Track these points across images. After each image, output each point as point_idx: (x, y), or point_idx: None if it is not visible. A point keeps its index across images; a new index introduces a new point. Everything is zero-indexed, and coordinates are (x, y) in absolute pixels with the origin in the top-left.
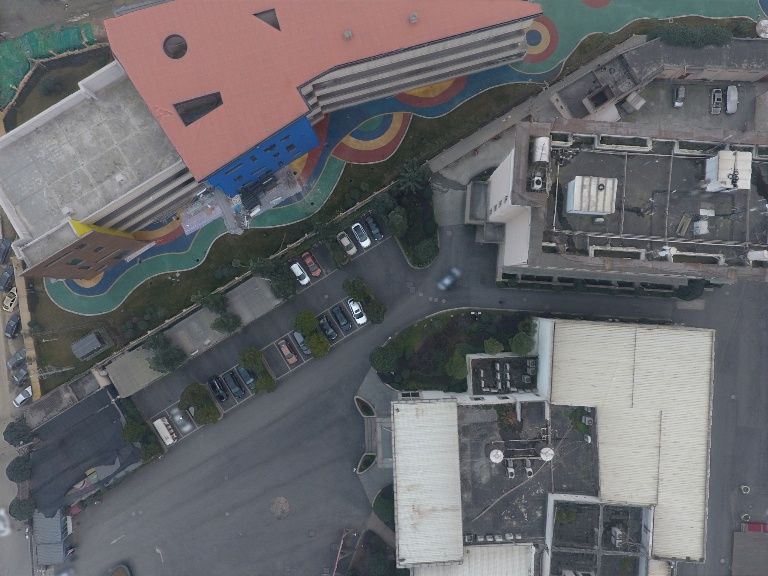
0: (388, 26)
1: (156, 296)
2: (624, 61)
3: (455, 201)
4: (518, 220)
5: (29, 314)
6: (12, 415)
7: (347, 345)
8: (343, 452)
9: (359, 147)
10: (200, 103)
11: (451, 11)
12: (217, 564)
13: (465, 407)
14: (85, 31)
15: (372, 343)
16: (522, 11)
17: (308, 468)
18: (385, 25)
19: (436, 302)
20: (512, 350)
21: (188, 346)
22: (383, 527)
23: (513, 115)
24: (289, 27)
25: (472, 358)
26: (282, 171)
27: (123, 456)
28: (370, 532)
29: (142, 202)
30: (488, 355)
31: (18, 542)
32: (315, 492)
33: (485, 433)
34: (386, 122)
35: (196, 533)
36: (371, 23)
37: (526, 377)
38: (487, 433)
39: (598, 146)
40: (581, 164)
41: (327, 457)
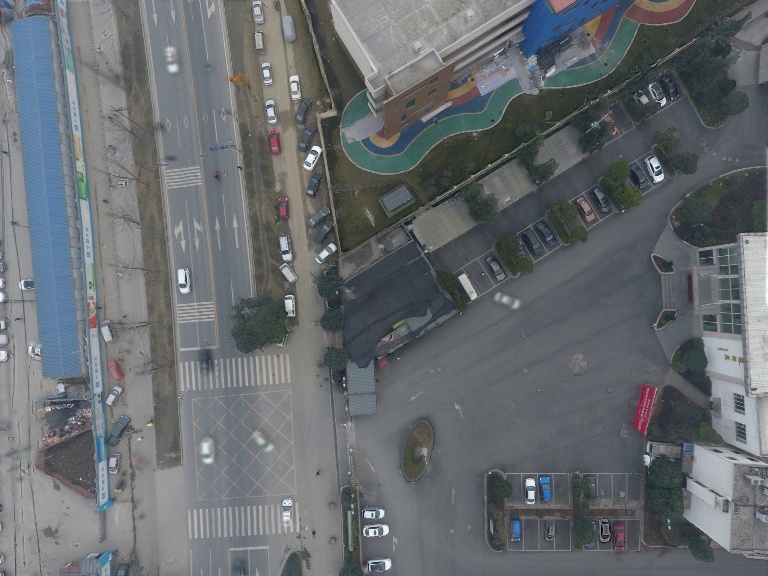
0: None
1: (454, 155)
2: None
3: (748, 61)
4: None
5: (328, 173)
6: (311, 273)
7: (642, 204)
8: (640, 309)
9: (652, 9)
10: None
11: None
12: (516, 420)
13: None
14: None
15: (667, 202)
16: None
17: (605, 325)
18: None
19: (730, 161)
20: None
21: None
22: (682, 382)
23: None
24: None
25: None
26: (576, 33)
27: (435, 307)
28: (671, 387)
29: (472, 47)
30: None
31: (319, 398)
32: (613, 349)
33: None
34: None
35: (495, 389)
36: None
37: None
38: None
39: None
40: None
41: (624, 314)
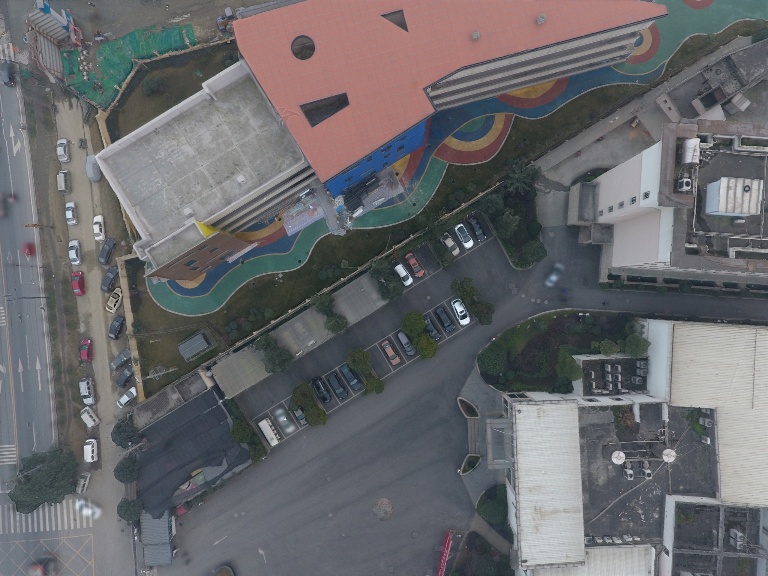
0: (515, 27)
1: (259, 297)
2: (731, 62)
3: (557, 202)
4: (639, 221)
5: (132, 315)
6: (115, 416)
7: (450, 346)
8: (446, 453)
9: (461, 148)
10: (320, 104)
11: (577, 12)
12: (320, 565)
13: (582, 408)
14: (186, 32)
15: (475, 344)
16: (647, 12)
17: (411, 469)
18: (512, 26)
19: (538, 303)
20: (626, 351)
21: (294, 347)
22: (487, 528)
23: (618, 116)
24: (417, 28)
25: (582, 359)
26: (384, 172)
27: (230, 457)
28: (474, 533)
29: (256, 203)
30: (596, 356)
31: (121, 543)
32: (418, 493)
33: (602, 434)
34: (488, 123)
35: (299, 534)
36: (498, 24)
37: (638, 378)
38: (604, 434)
39: (739, 147)
40: (719, 165)
41: (430, 458)
